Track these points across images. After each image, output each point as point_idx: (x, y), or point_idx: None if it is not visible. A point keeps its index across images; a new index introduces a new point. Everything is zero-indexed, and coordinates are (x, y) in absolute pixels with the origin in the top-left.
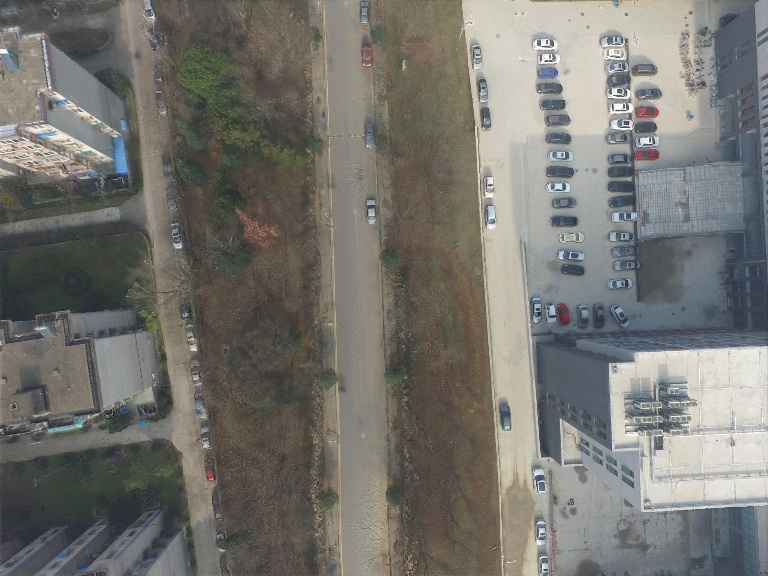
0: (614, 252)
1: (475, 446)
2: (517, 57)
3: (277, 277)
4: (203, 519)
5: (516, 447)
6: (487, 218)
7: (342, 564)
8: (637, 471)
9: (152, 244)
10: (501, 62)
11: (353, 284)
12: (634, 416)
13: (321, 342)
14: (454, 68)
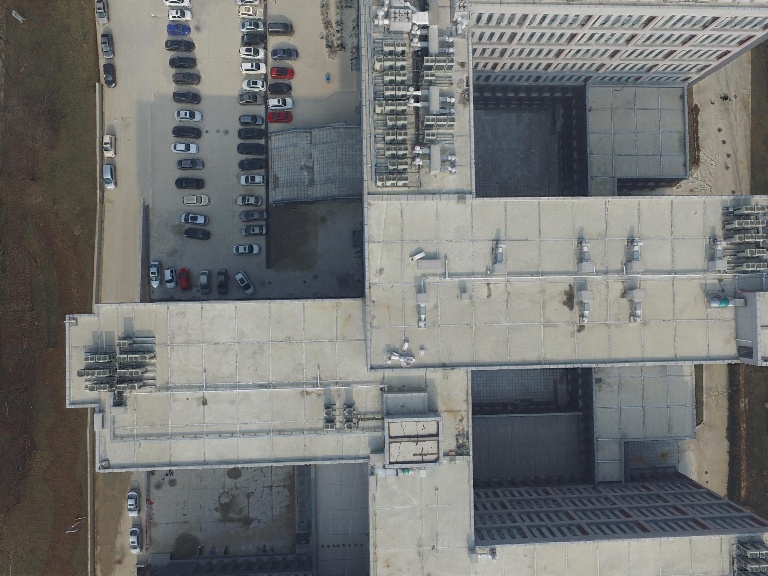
0: (241, 216)
1: (60, 412)
2: (148, 13)
3: None
4: None
5: None
6: (103, 177)
7: None
8: None
9: None
10: (131, 17)
11: None
12: None
13: None
14: (79, 22)
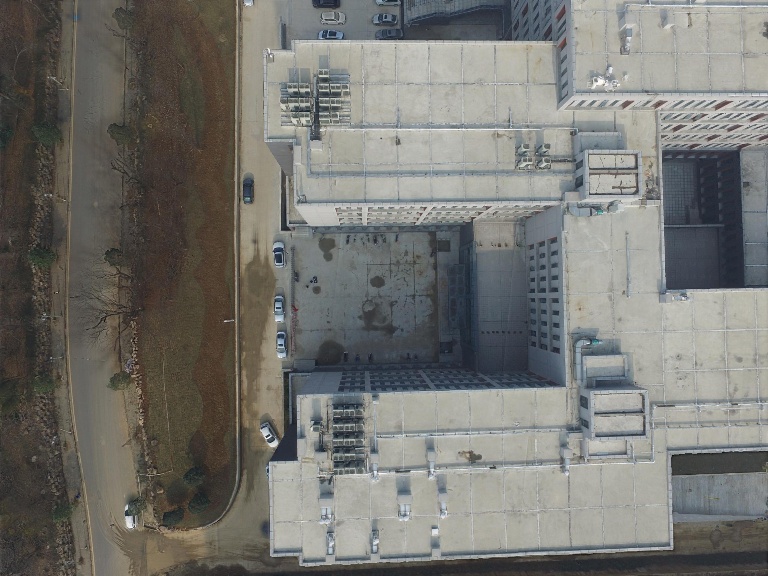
0: (377, 35)
1: (208, 213)
2: None
3: None
4: None
5: (258, 222)
6: None
7: (68, 335)
8: None
9: None
10: None
11: (95, 52)
12: None
13: (56, 107)
14: None
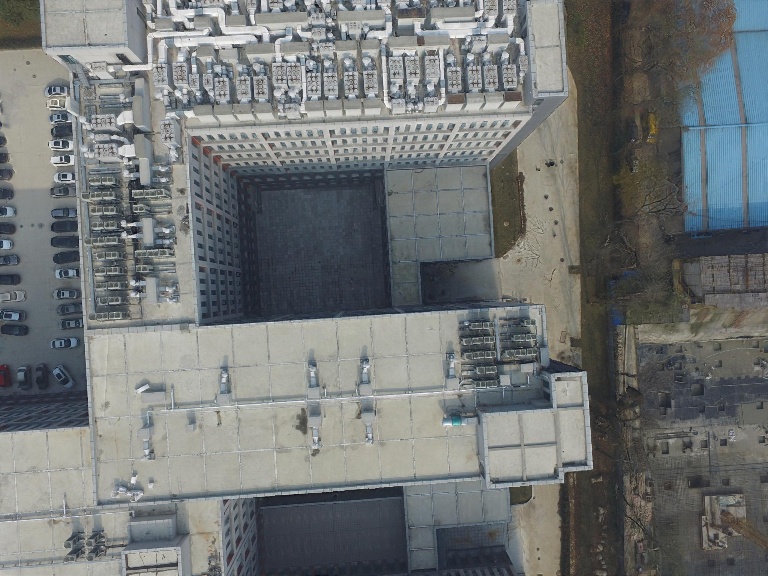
0: (58, 310)
1: None
2: None
3: None
4: None
5: None
6: None
7: None
8: None
9: None
10: None
11: None
12: None
13: None
14: None
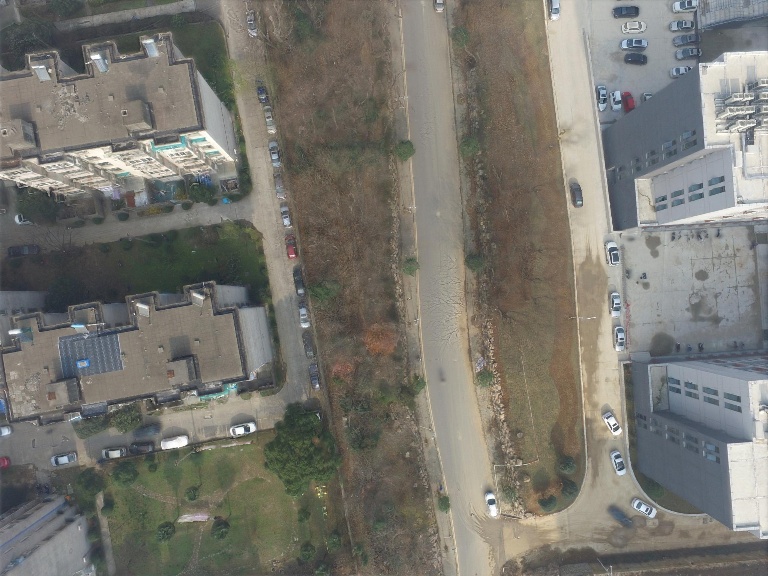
0: (676, 41)
1: (549, 218)
2: None
3: (365, 14)
4: (284, 298)
5: (588, 224)
6: (551, 8)
7: (422, 338)
8: (729, 169)
9: (227, 34)
10: None
11: (423, 70)
12: (727, 108)
13: (394, 125)
14: None
